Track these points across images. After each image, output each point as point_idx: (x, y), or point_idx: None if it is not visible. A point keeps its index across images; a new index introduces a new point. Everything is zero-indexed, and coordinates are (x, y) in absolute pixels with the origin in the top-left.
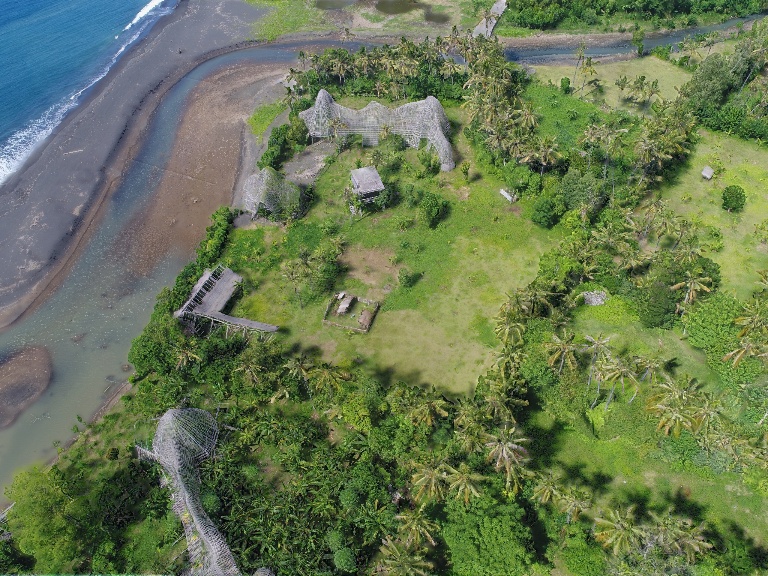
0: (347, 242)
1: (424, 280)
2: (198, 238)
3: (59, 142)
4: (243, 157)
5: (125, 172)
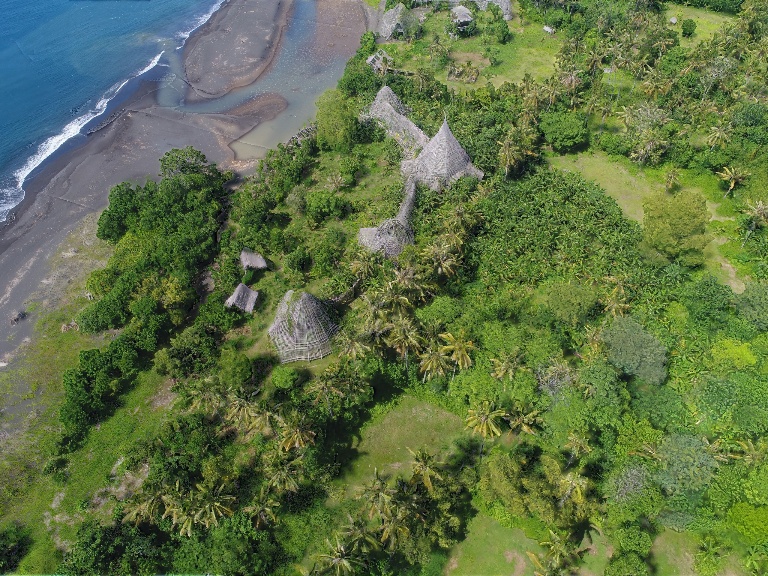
0: (451, 49)
1: (503, 64)
2: (352, 51)
3: (237, 8)
4: (367, 17)
5: (289, 23)
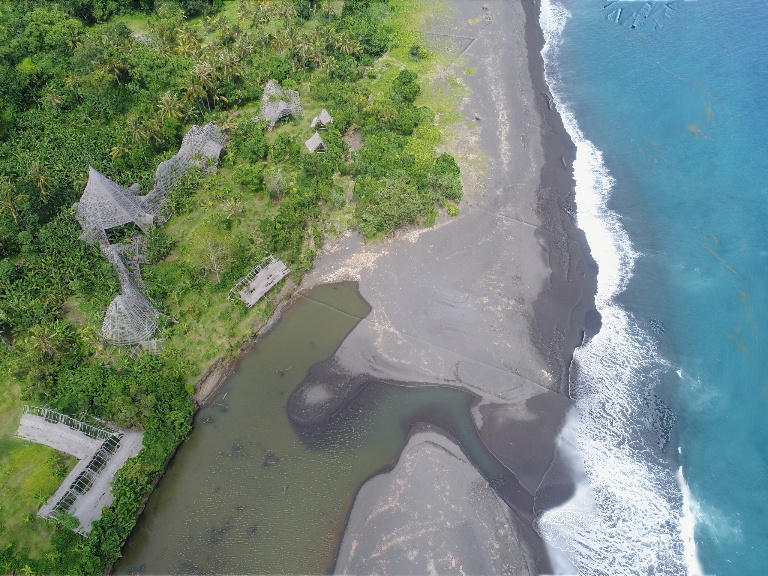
0: None
1: None
2: None
3: None
4: None
5: None
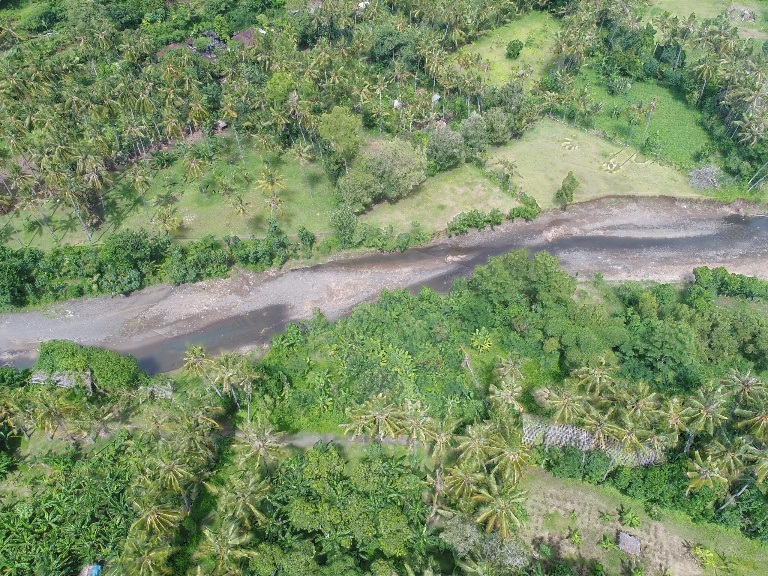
0: None
1: None
2: None
3: None
4: None
5: None
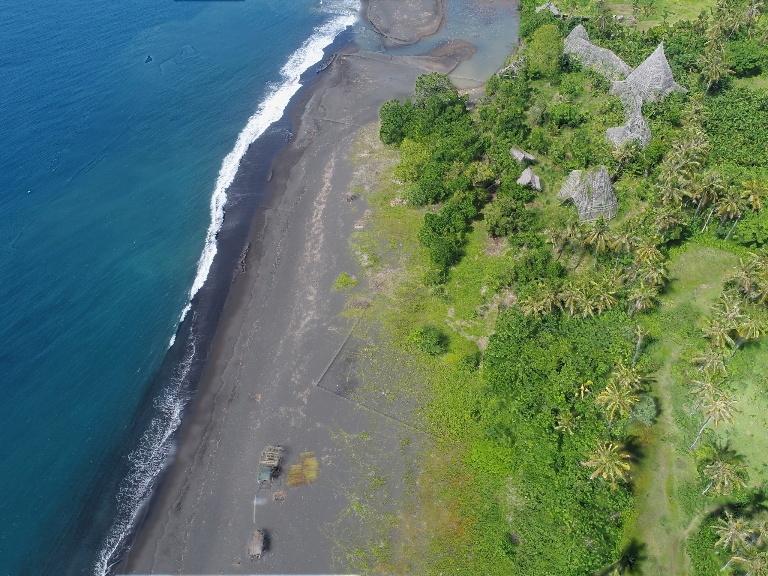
0: None
1: None
2: (511, 6)
3: None
4: None
5: None
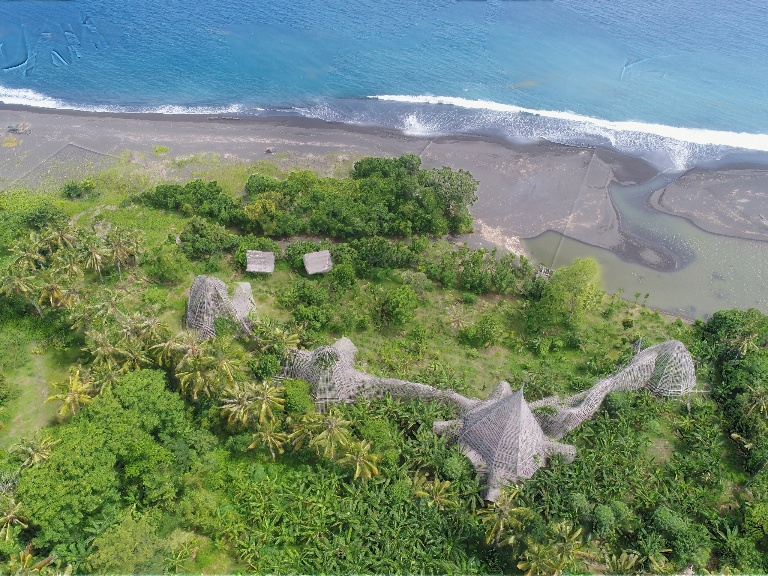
0: None
1: None
2: None
3: None
4: None
5: None
